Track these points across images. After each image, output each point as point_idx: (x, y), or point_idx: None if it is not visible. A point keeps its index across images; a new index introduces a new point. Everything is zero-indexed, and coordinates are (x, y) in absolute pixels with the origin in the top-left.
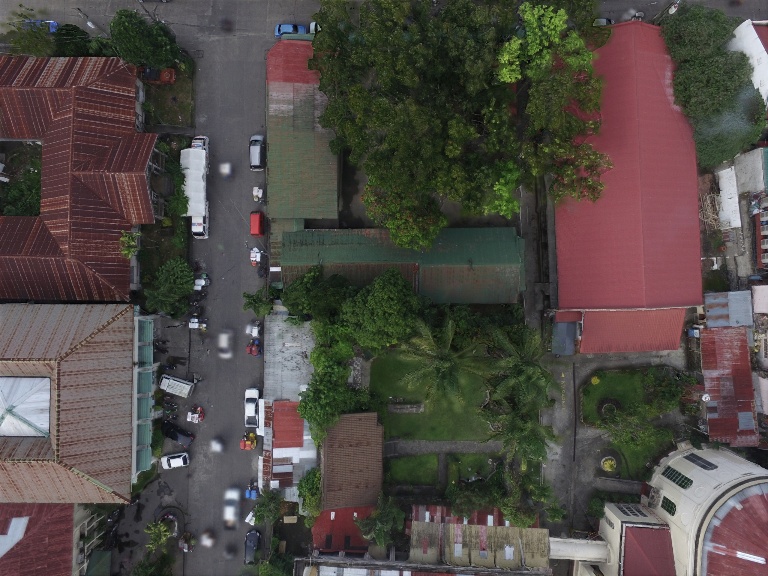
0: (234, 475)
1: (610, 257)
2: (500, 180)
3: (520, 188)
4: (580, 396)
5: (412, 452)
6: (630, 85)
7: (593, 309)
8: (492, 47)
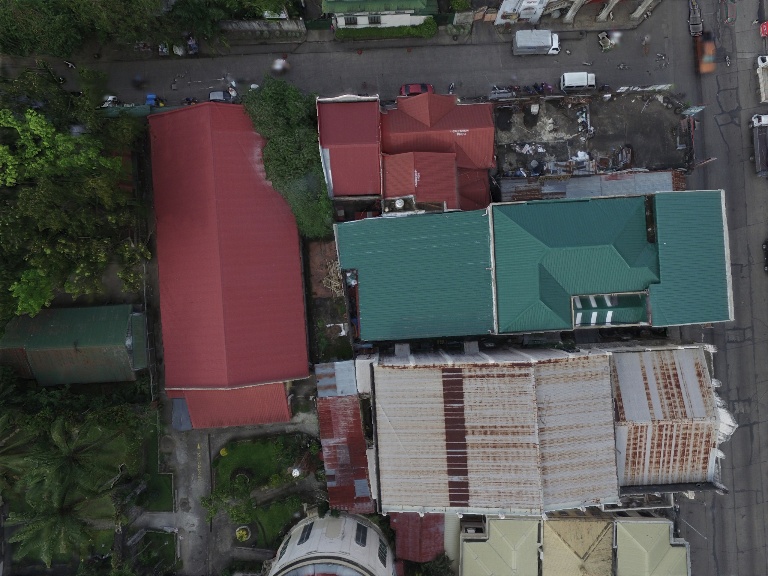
0: None
1: (201, 336)
2: (21, 280)
3: (143, 264)
4: None
5: None
6: (208, 166)
7: (187, 388)
8: None
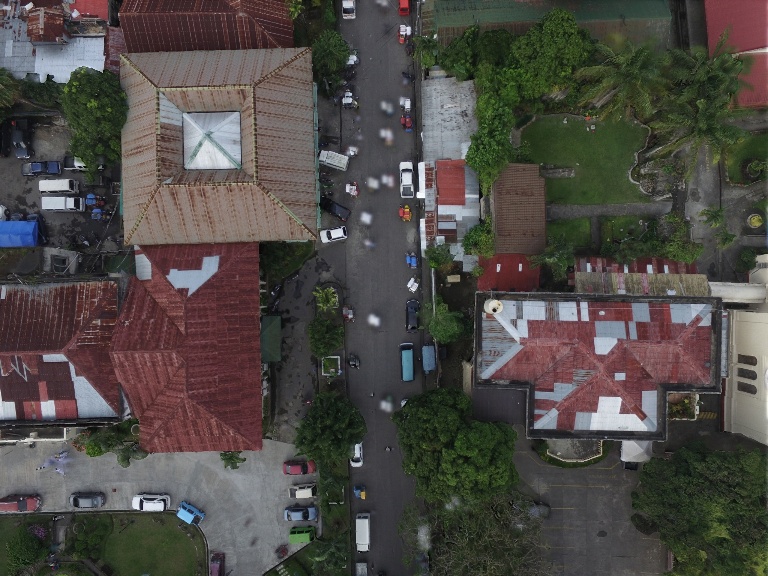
0: (390, 248)
1: None
2: None
3: None
4: (724, 157)
5: (564, 217)
6: None
7: (748, 51)
8: None
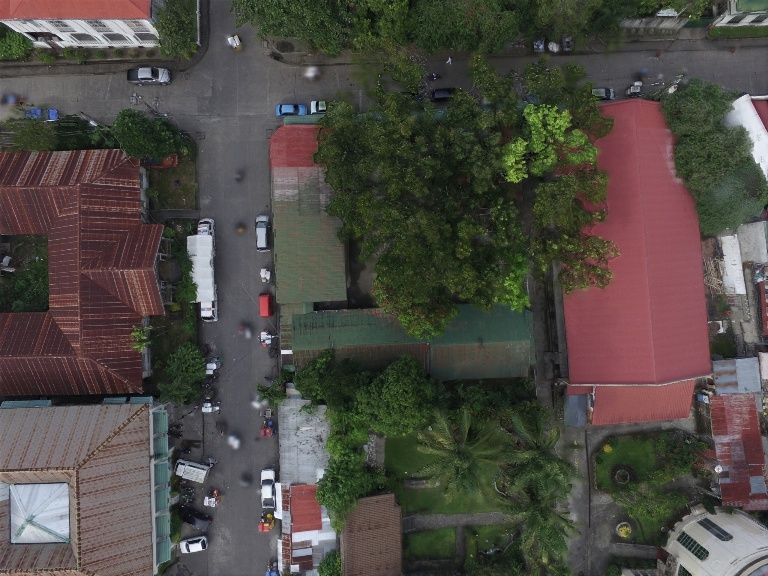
0: (253, 556)
1: (619, 332)
2: (510, 274)
3: None
4: (593, 463)
5: (429, 526)
6: (633, 162)
7: (604, 384)
8: (499, 150)
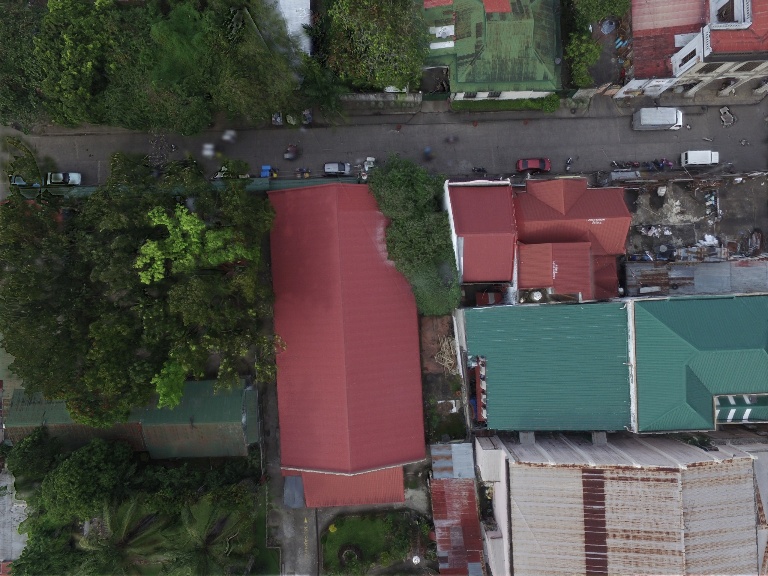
0: None
1: (321, 418)
2: (161, 371)
3: None
4: None
5: None
6: (334, 247)
7: (306, 470)
8: (125, 252)
